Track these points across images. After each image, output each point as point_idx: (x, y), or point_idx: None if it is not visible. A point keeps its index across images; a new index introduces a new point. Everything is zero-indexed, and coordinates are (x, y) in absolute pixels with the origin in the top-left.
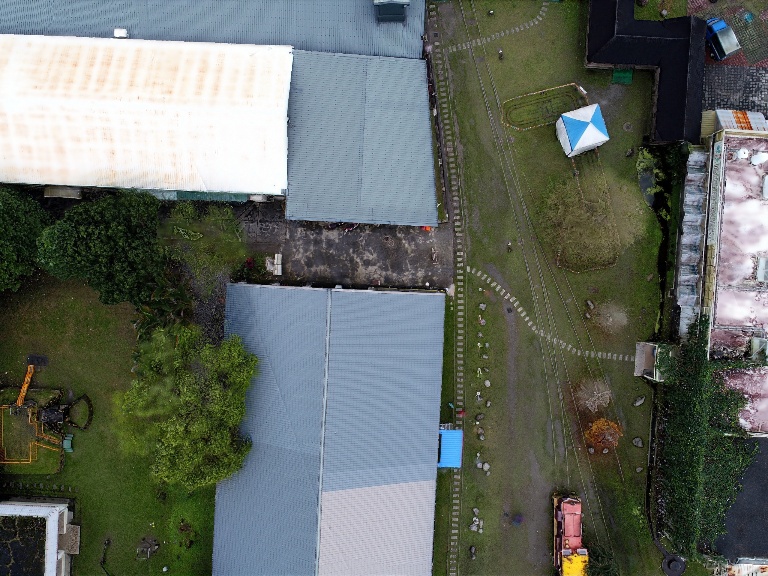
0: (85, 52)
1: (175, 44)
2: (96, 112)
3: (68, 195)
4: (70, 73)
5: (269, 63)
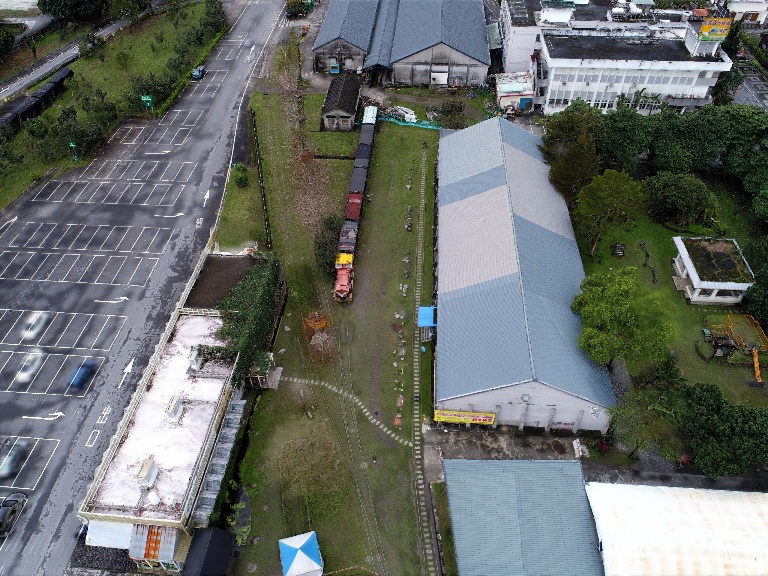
0: None
1: None
2: None
3: None
4: None
5: None
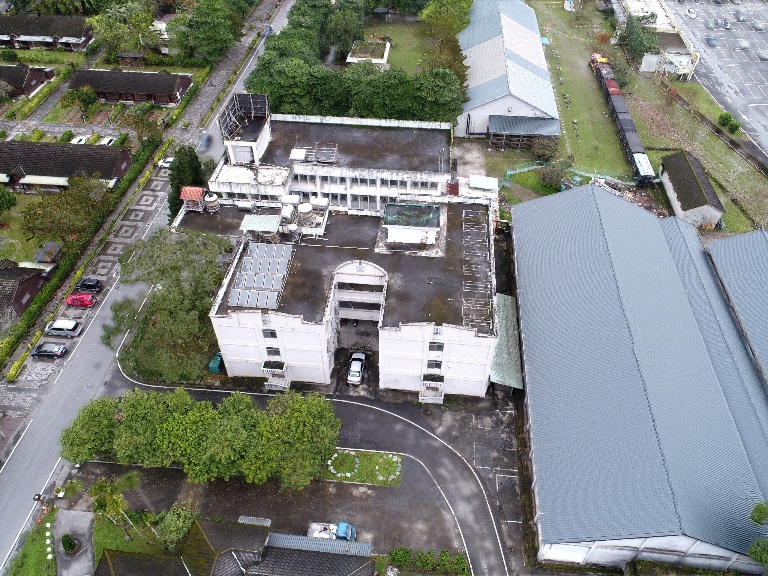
0: None
1: None
2: None
3: None
4: None
5: None
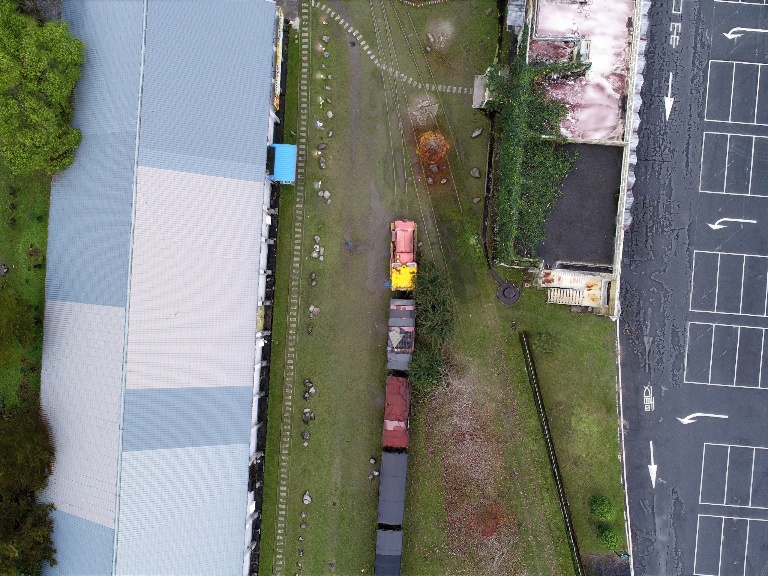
0: None
1: None
2: None
3: None
4: None
5: None
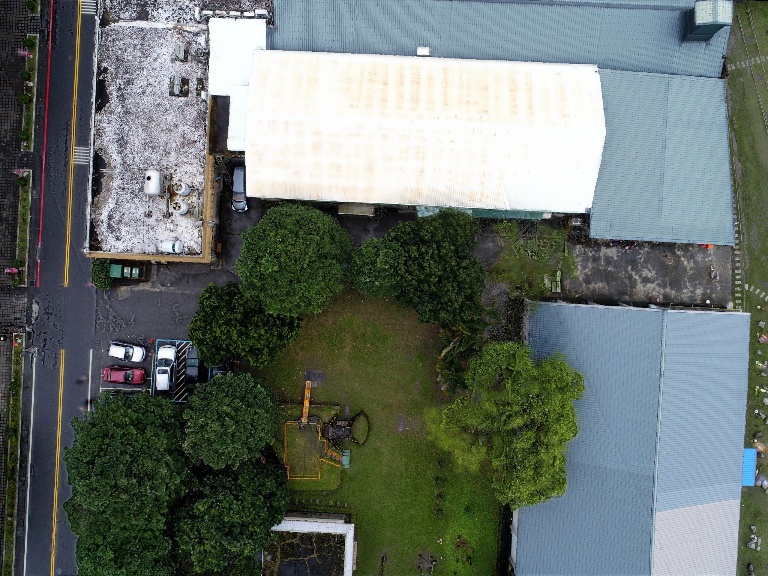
0: (392, 70)
1: (480, 62)
2: (413, 131)
3: (363, 212)
4: (382, 91)
5: (577, 82)
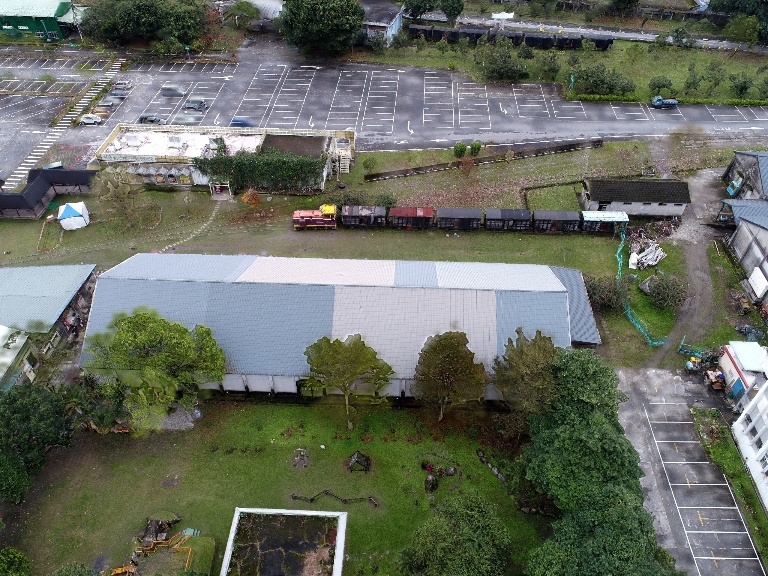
0: None
1: None
2: None
3: None
4: None
5: None
